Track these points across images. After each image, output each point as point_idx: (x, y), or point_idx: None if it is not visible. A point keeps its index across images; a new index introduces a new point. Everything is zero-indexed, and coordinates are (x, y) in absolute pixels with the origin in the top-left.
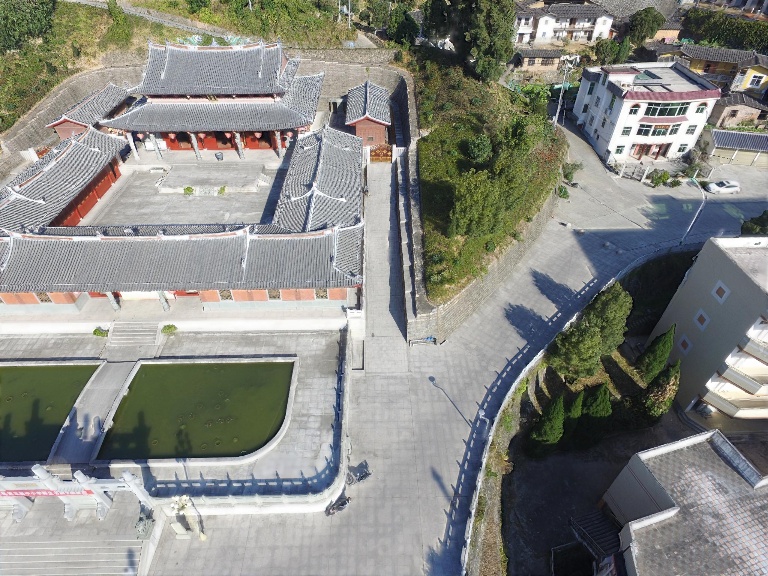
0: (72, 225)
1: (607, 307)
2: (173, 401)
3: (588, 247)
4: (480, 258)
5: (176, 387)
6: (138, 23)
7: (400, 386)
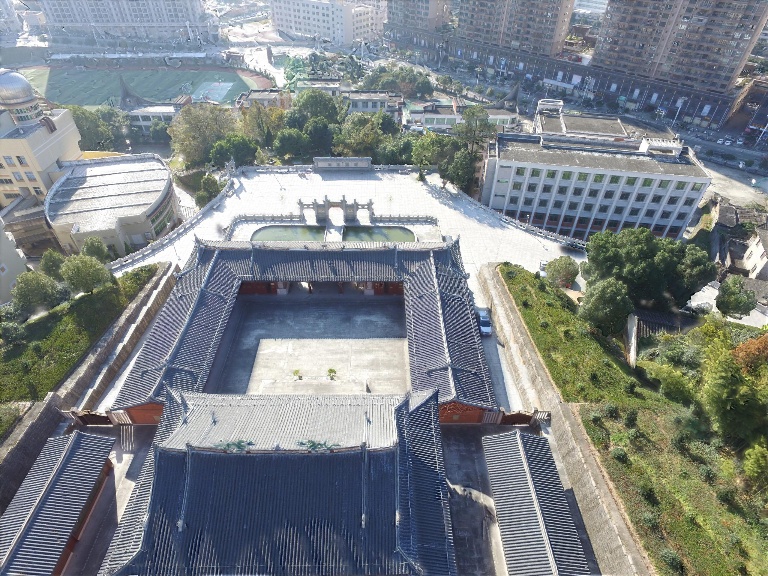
0: None
1: (61, 256)
2: None
3: None
4: None
5: None
6: None
7: None
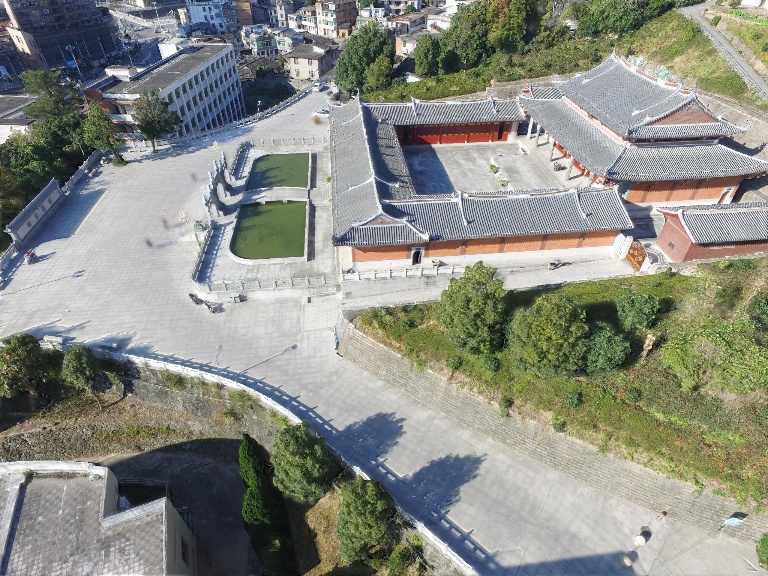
0: (429, 142)
1: None
2: (277, 218)
3: (583, 567)
4: (434, 355)
5: (288, 217)
6: (699, 44)
7: (289, 326)
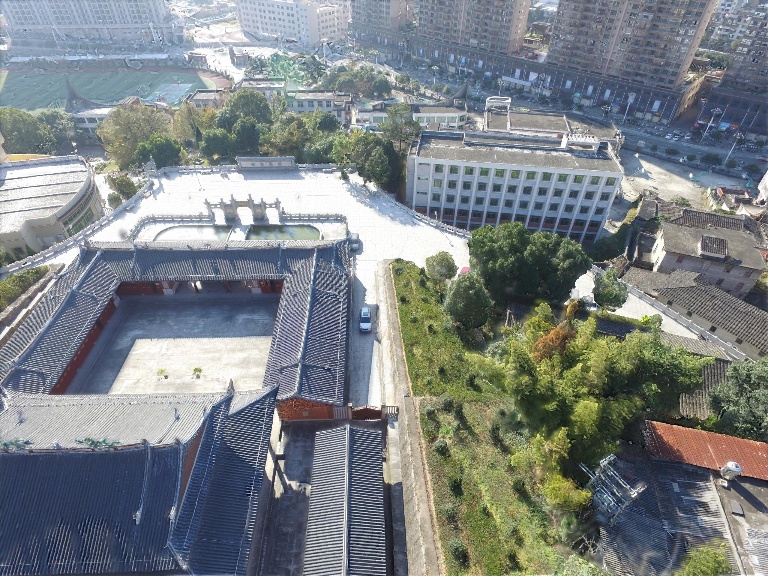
0: None
1: None
2: None
3: None
4: None
5: None
6: None
7: None
